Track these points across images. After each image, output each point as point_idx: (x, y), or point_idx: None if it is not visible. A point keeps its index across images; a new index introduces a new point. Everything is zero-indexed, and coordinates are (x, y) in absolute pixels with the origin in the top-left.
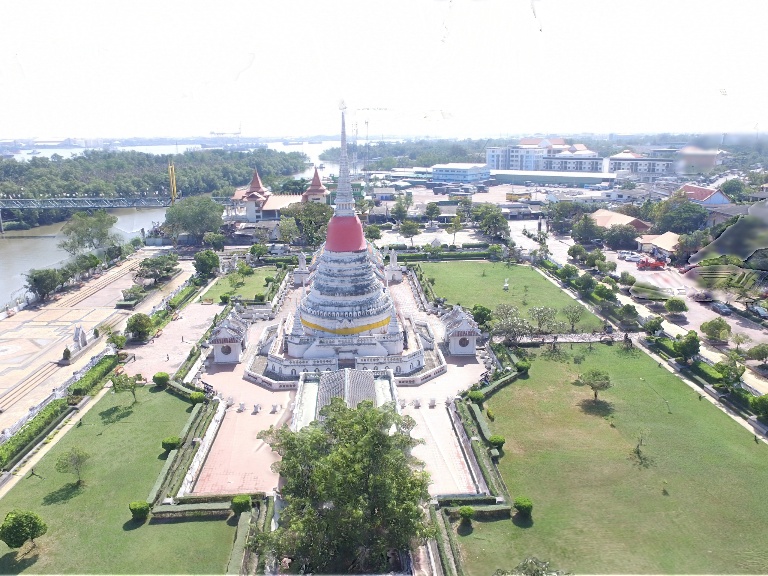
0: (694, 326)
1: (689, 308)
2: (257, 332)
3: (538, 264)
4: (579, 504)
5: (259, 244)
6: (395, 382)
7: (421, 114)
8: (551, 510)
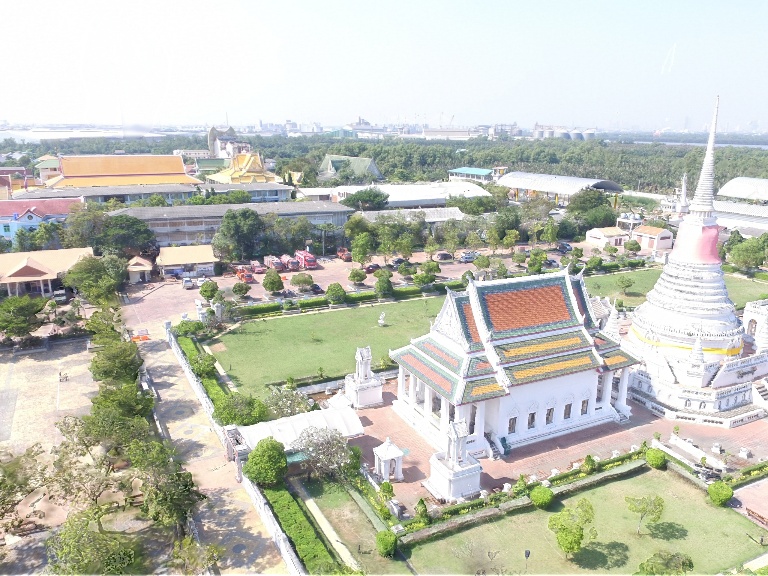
0: (447, 275)
1: (398, 275)
2: (739, 433)
3: (244, 316)
4: (734, 295)
5: (339, 571)
6: (761, 300)
7: (762, 121)
8: (749, 298)
